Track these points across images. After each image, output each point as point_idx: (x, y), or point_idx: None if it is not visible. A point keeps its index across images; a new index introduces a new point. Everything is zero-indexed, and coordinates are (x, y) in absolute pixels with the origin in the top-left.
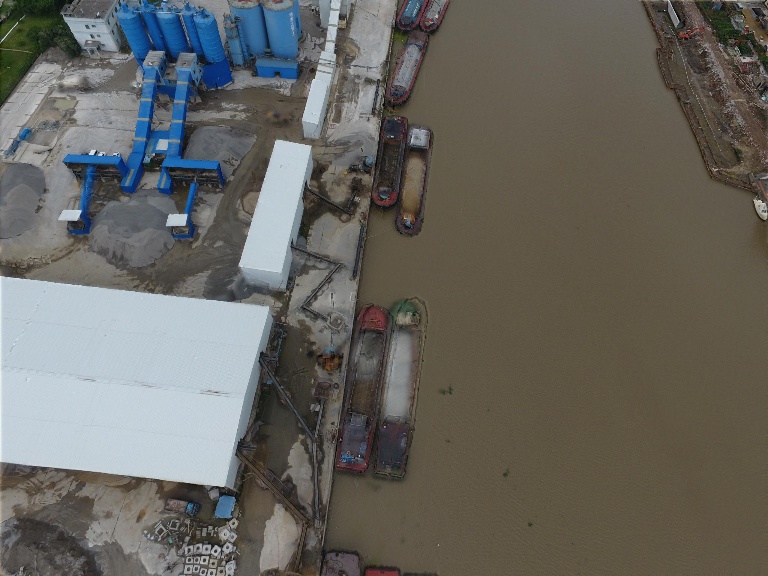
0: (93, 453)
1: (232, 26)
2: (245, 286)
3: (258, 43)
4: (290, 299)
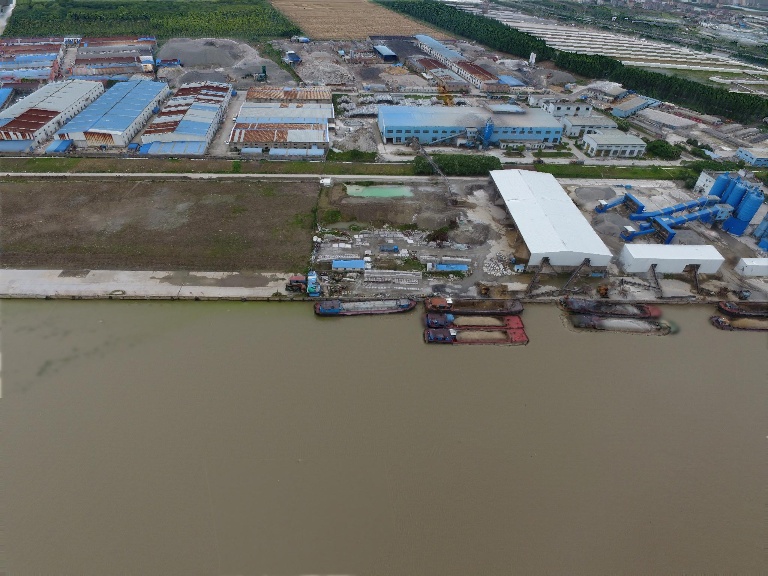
0: (522, 223)
1: None
2: (616, 259)
3: None
4: (623, 277)
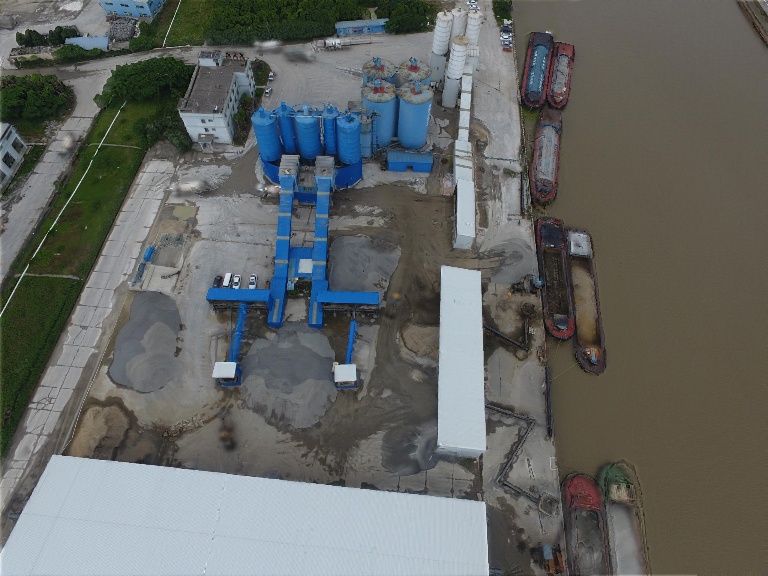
0: None
1: (368, 122)
2: (430, 454)
3: (387, 133)
4: (482, 468)
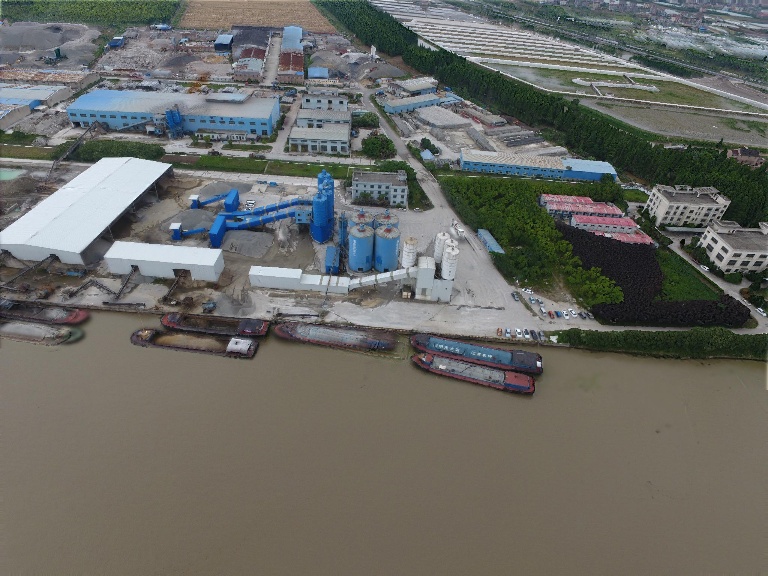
0: None
1: None
2: None
3: None
4: (105, 278)
